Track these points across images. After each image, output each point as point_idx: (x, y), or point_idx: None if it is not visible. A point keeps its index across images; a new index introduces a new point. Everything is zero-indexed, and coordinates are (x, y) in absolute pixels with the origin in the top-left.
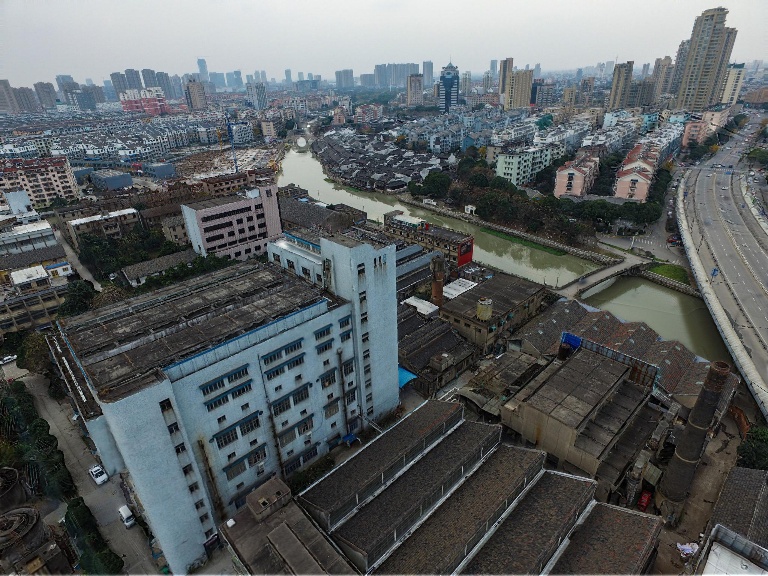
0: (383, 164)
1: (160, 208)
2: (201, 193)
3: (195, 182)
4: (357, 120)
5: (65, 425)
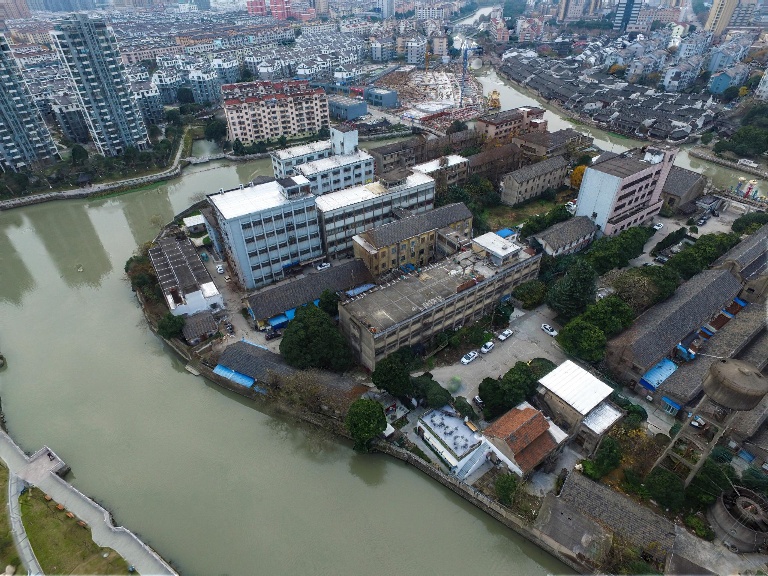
0: (636, 105)
1: (479, 156)
2: (484, 135)
3: (424, 114)
4: (524, 38)
5: (664, 425)
